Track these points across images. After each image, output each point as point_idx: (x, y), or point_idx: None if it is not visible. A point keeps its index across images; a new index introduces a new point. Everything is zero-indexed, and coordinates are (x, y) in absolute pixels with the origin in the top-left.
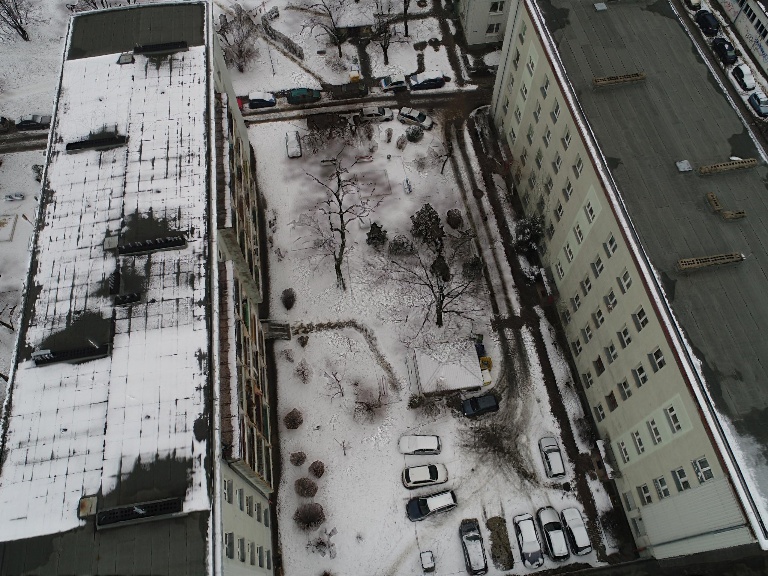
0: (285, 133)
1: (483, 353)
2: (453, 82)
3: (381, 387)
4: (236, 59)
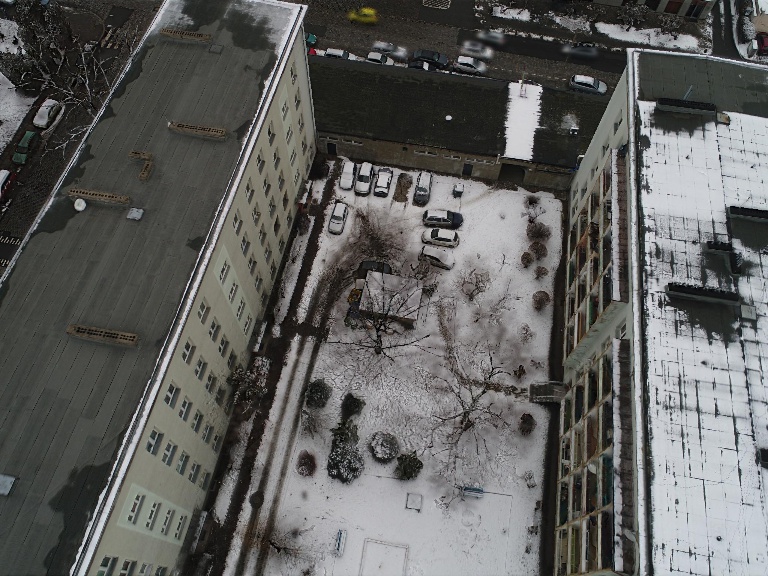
0: None
1: (353, 304)
2: None
3: None
4: None
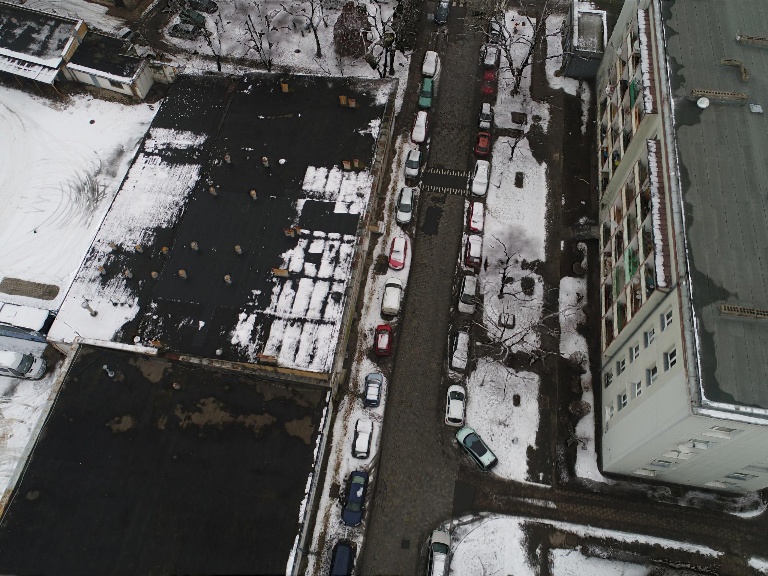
0: None
1: None
2: None
3: None
4: None
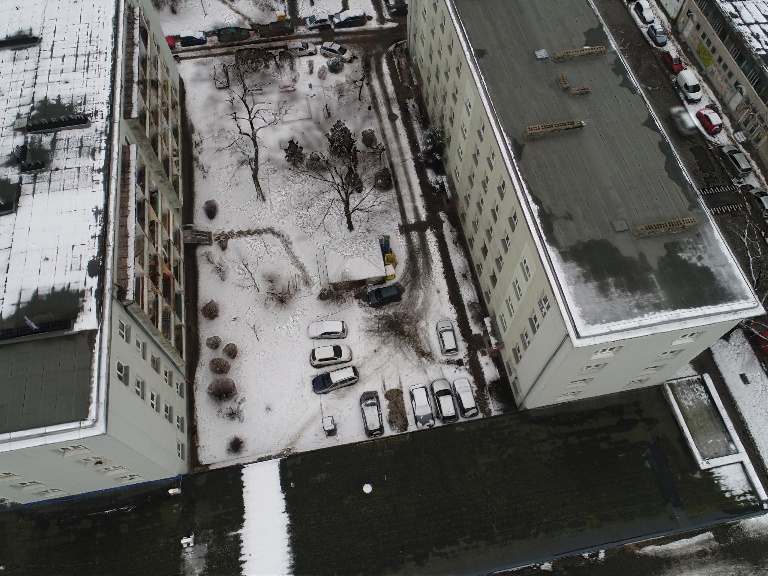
0: (214, 67)
1: (388, 251)
2: (375, 20)
3: (294, 283)
4: (169, 2)
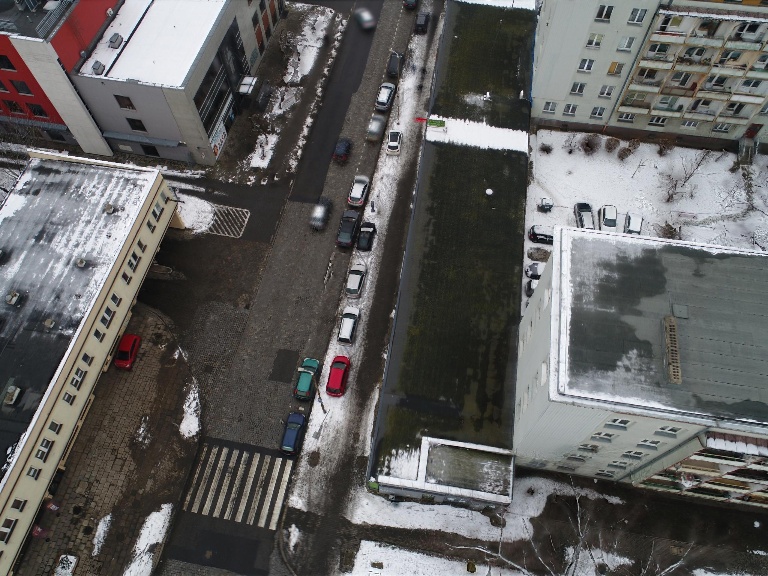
0: None
1: None
2: None
3: (687, 212)
4: None
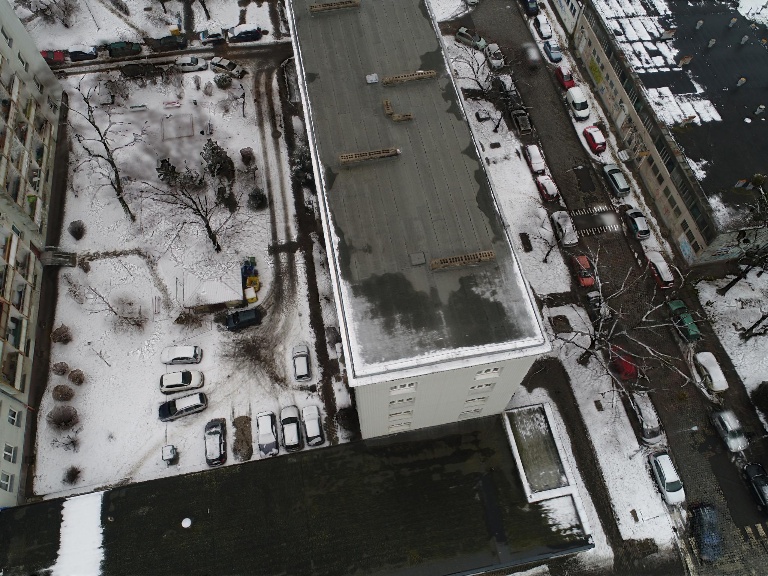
0: None
1: (251, 273)
2: (270, 35)
3: (153, 306)
4: (63, 16)
